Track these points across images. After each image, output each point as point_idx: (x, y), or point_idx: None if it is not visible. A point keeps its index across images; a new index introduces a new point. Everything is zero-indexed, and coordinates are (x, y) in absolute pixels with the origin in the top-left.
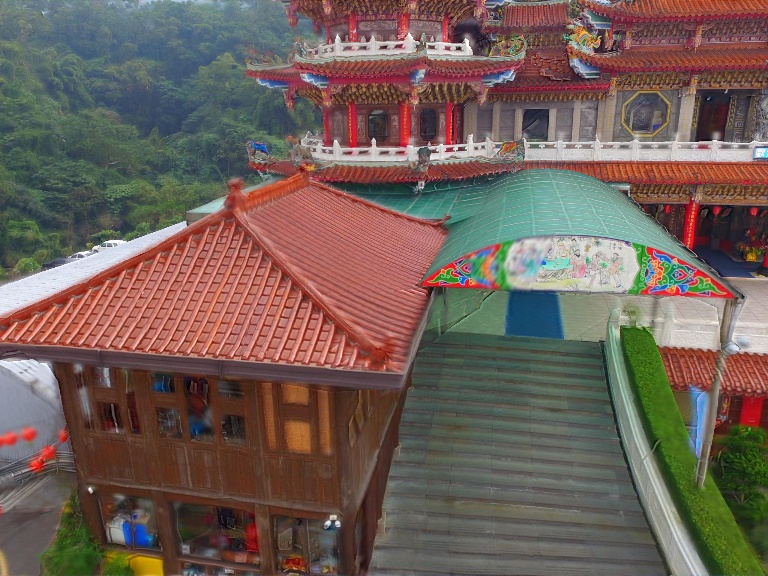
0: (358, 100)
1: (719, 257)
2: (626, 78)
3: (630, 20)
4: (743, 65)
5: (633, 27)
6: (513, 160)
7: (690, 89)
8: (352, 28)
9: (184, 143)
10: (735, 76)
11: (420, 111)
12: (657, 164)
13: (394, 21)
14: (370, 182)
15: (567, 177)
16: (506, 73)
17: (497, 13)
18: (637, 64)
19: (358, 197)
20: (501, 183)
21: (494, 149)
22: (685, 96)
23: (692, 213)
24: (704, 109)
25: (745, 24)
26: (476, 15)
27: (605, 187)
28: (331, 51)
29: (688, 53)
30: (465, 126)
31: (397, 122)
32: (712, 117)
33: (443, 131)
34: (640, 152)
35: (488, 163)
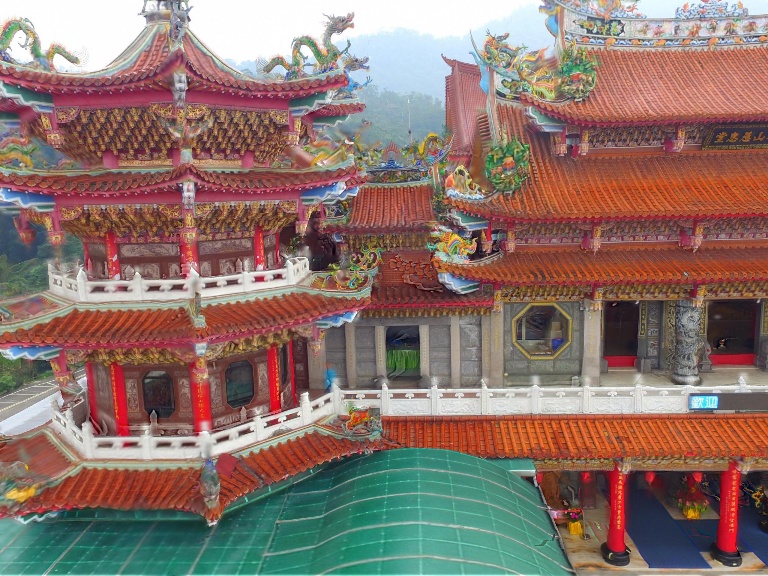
0: (122, 361)
1: (652, 510)
2: (513, 290)
3: (511, 221)
4: (657, 279)
5: (515, 225)
6: (366, 436)
7: (594, 304)
8: (110, 254)
9: (37, 272)
10: (647, 287)
11: (224, 368)
12: (566, 420)
13: (174, 245)
14: (132, 509)
15: (443, 488)
16: (346, 315)
17: (341, 205)
18: (526, 278)
19: (108, 542)
20: (343, 502)
21: (343, 400)
22: (588, 310)
23: (619, 483)
24: (610, 315)
25: (650, 223)
26: (299, 232)
27: (501, 506)
28: (76, 289)
29: (586, 256)
30: (309, 348)
31: (187, 388)
32: (620, 324)
33: (265, 387)
34: (542, 402)
35: (331, 437)
